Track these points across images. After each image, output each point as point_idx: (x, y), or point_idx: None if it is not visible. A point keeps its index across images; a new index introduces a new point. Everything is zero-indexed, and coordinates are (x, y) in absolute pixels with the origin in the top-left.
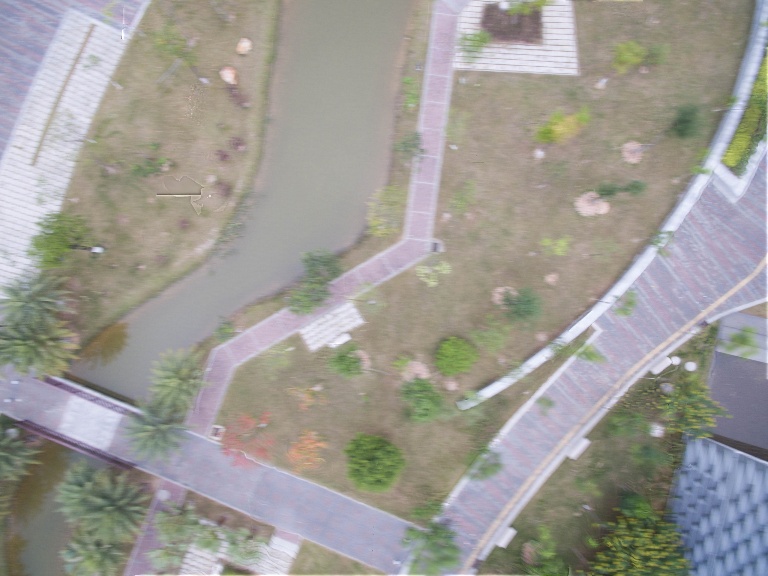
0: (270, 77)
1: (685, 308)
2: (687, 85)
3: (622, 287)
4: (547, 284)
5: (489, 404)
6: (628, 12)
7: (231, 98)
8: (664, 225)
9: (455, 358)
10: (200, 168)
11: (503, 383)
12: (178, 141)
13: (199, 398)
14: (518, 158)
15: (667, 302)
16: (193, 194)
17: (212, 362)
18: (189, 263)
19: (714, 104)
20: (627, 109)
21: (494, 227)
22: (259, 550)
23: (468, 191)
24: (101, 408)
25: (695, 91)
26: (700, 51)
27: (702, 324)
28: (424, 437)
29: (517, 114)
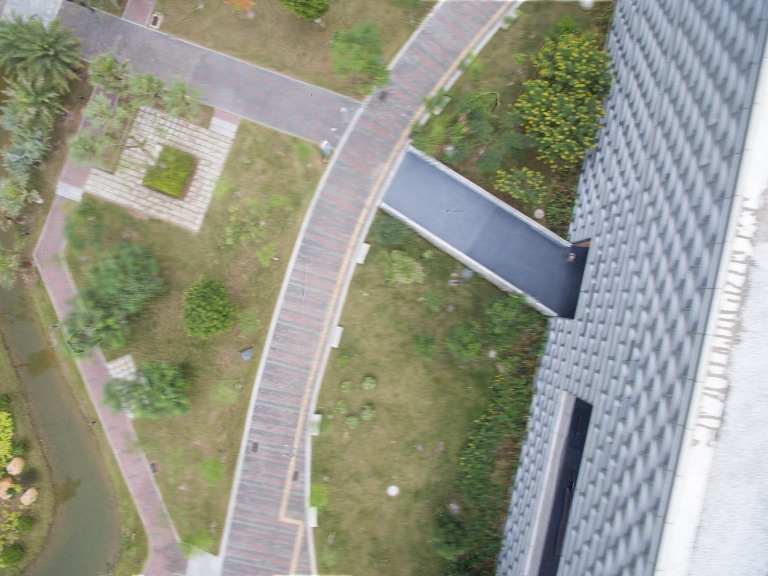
0: None
1: None
2: None
3: None
4: None
5: None
6: None
7: None
8: None
9: None
10: None
11: None
12: None
13: None
14: None
15: None
16: None
17: None
18: None
19: None
20: None
21: None
22: (199, 136)
23: None
24: None
25: None
26: None
27: None
28: (359, 11)
29: None
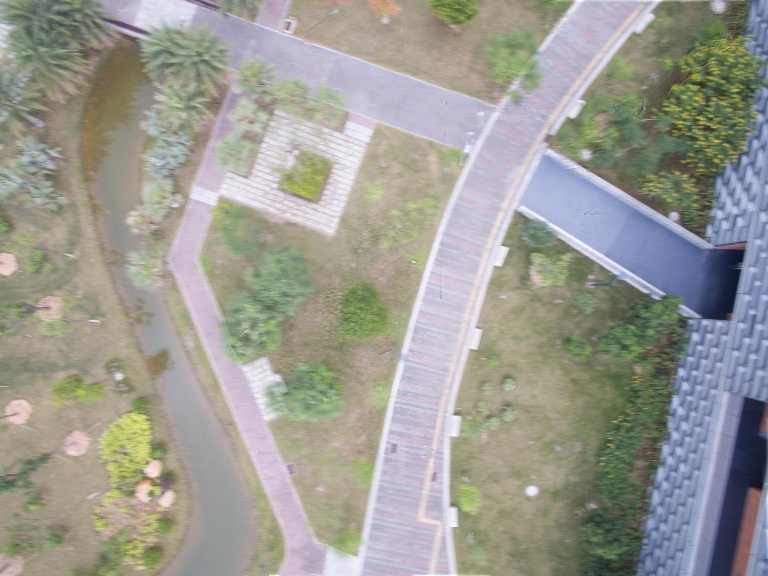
0: None
1: None
2: None
3: None
4: None
5: None
6: None
7: None
8: None
9: None
10: None
11: None
12: None
13: None
14: None
15: None
16: None
17: None
18: None
19: None
20: None
21: None
22: (333, 140)
23: None
24: None
25: None
26: None
27: None
28: (494, 16)
29: None
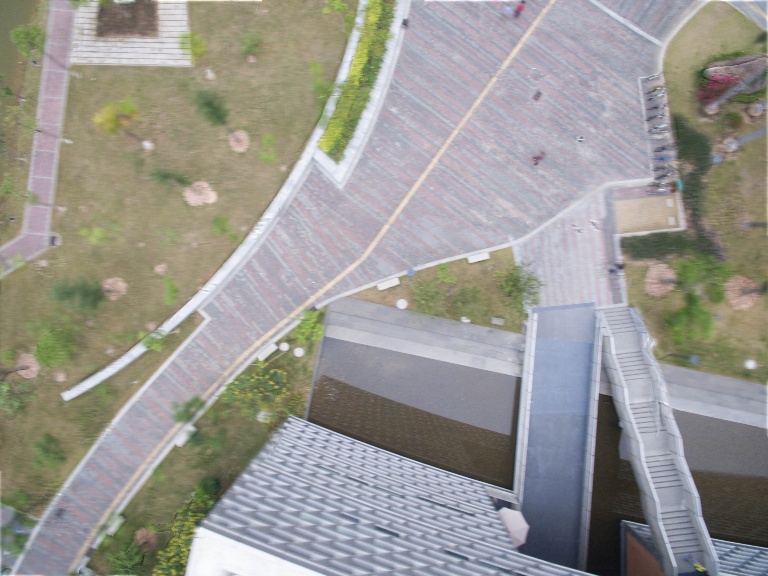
0: None
1: (293, 294)
2: (294, 73)
3: (221, 275)
4: (156, 274)
5: (94, 394)
6: (239, 2)
7: None
8: None
9: (52, 350)
10: None
11: (105, 373)
12: None
13: None
14: (129, 150)
15: (275, 289)
16: None
17: None
18: None
19: (320, 91)
20: (235, 98)
21: (105, 219)
22: None
23: (82, 184)
24: None
25: (302, 79)
26: (308, 39)
27: (311, 310)
28: (36, 429)
29: (129, 107)
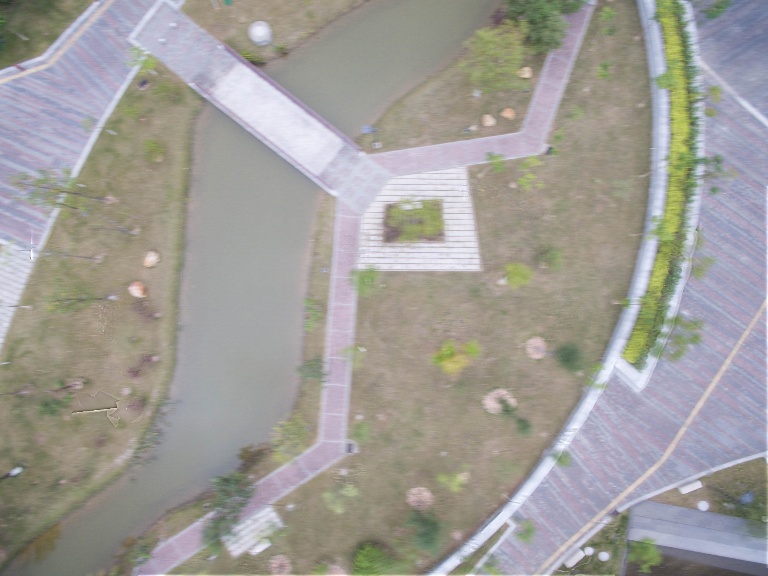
0: (180, 285)
1: (595, 499)
2: (586, 278)
3: (531, 486)
4: (459, 483)
5: None
6: (526, 207)
7: (142, 312)
8: (569, 422)
9: (370, 569)
10: (115, 382)
11: None
12: (91, 358)
13: None
14: (425, 358)
15: (578, 494)
16: (109, 408)
17: None
18: (109, 474)
19: (613, 296)
20: (529, 305)
21: (405, 428)
22: None
23: (378, 392)
24: None
25: (595, 284)
26: (598, 243)
27: (613, 513)
28: None
29: (423, 314)
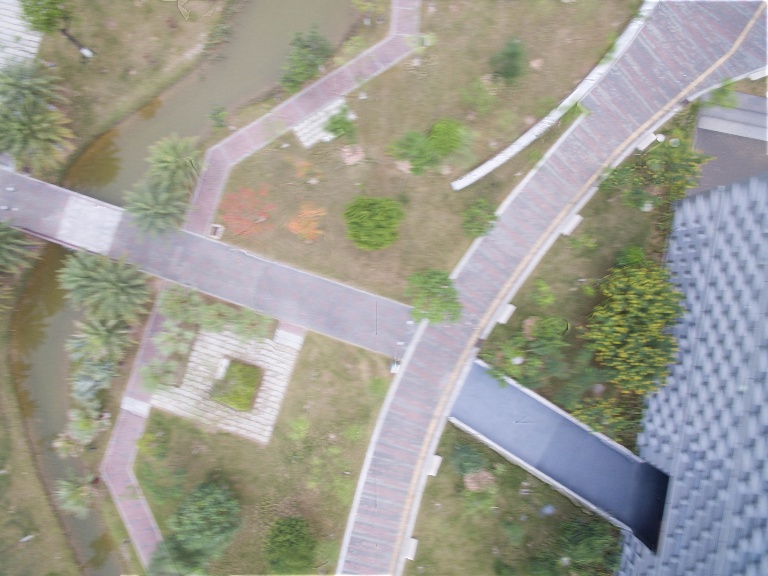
0: None
1: (667, 87)
2: None
3: (605, 64)
4: (533, 69)
5: (483, 184)
6: None
7: None
8: (643, 4)
9: (448, 136)
10: None
11: (495, 162)
12: None
13: (196, 193)
14: None
15: (649, 82)
16: None
17: (208, 160)
18: (179, 69)
19: None
20: None
21: (479, 17)
22: (264, 347)
23: None
24: (98, 206)
25: None
26: None
27: (683, 102)
28: (421, 222)
29: None
